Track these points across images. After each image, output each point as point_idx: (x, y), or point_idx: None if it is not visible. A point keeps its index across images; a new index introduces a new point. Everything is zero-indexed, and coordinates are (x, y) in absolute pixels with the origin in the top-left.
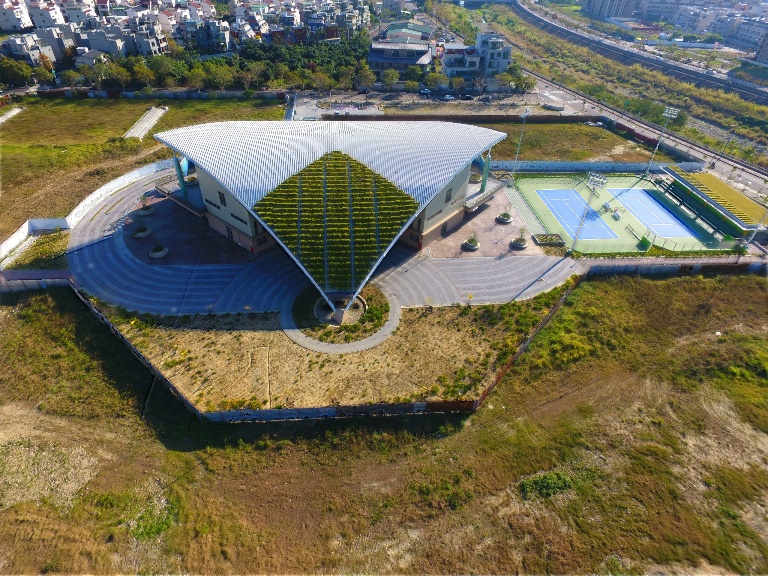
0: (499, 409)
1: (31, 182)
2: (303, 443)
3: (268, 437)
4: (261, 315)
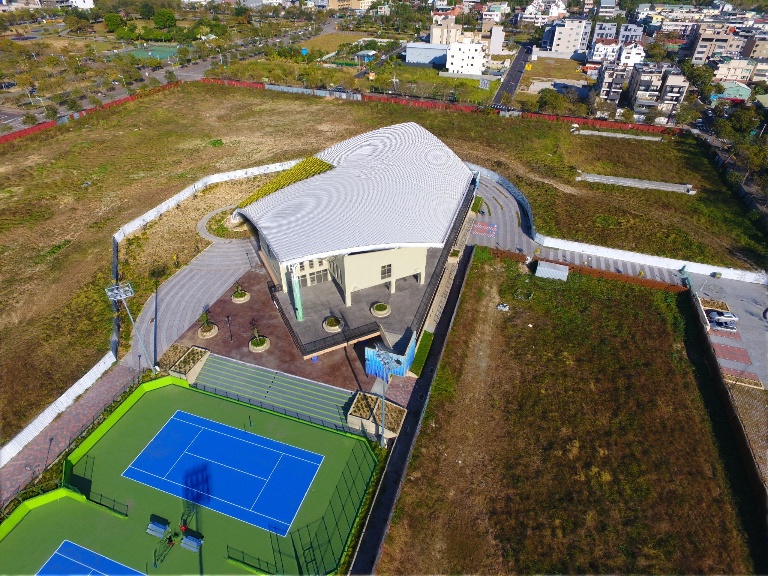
0: (105, 252)
1: (491, 149)
2: None
3: None
4: None
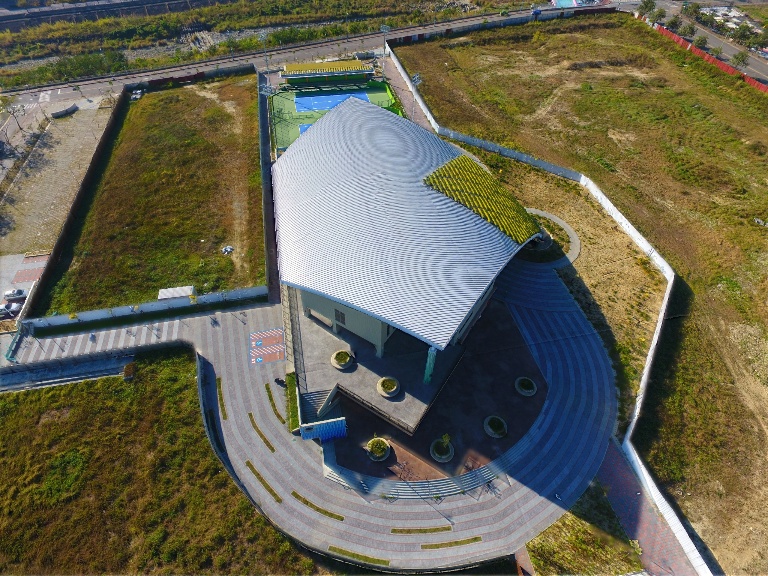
0: None
1: None
2: (646, 238)
3: (656, 250)
4: (564, 278)
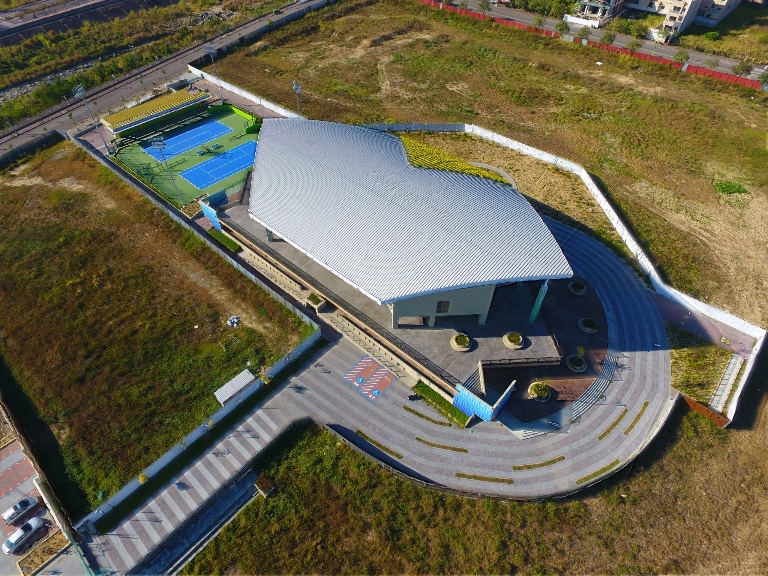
0: None
1: None
2: None
3: None
4: None
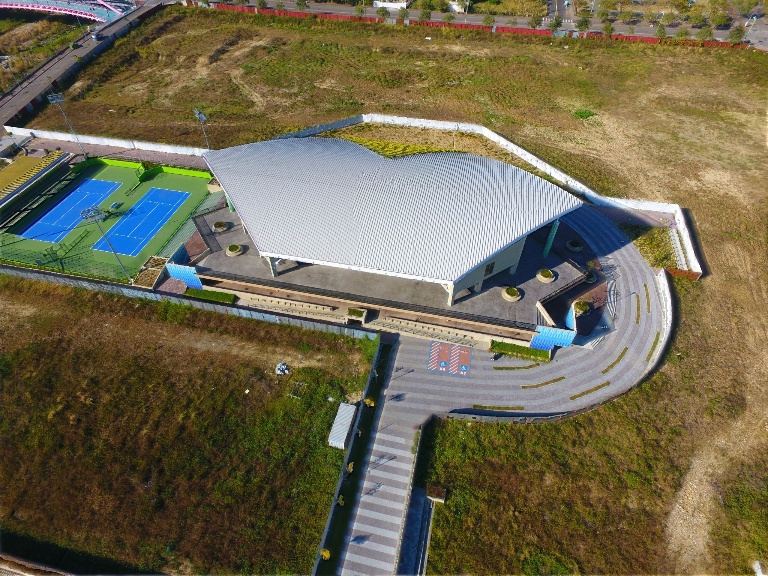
0: None
1: None
2: None
3: None
4: None
